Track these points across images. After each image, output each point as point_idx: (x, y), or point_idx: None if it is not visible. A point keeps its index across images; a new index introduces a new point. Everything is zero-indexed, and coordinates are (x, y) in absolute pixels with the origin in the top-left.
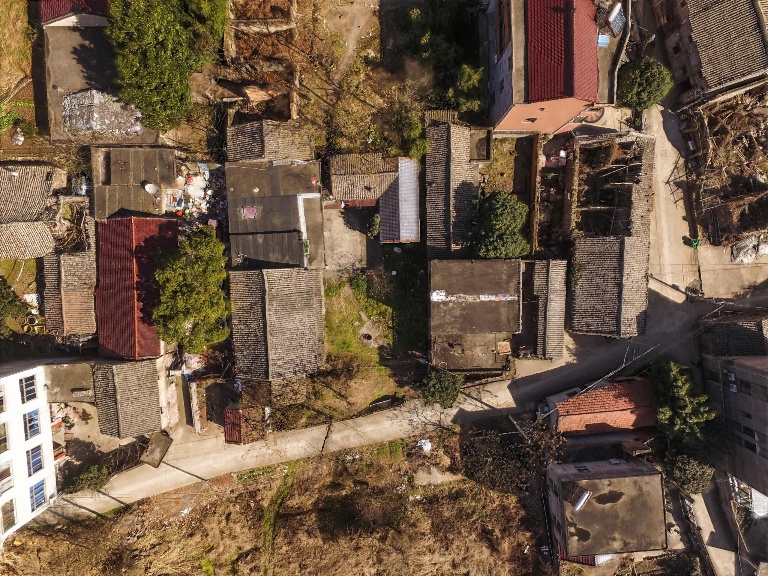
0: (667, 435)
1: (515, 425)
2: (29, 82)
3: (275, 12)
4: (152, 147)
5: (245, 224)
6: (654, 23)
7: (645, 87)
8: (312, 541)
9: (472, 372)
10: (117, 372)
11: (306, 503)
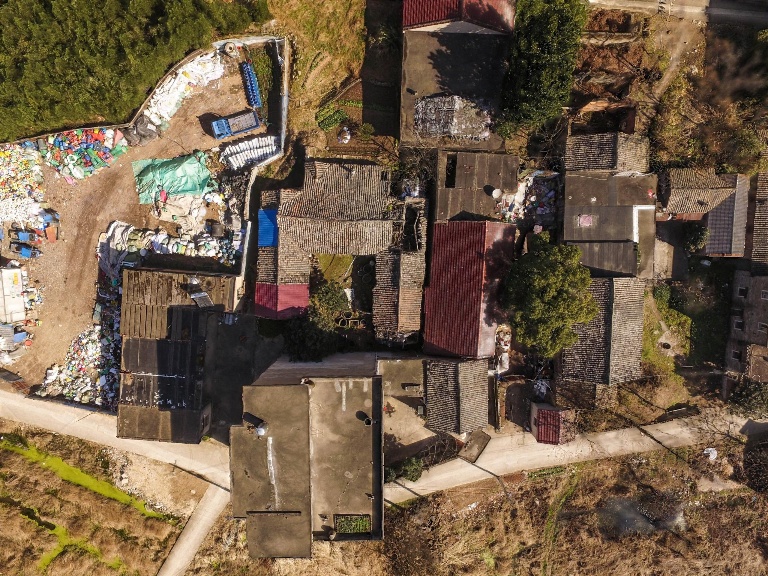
0: None
1: None
2: (358, 82)
3: (611, 25)
4: (497, 153)
5: (580, 232)
6: None
7: None
8: (592, 540)
9: None
10: (460, 370)
11: (590, 503)
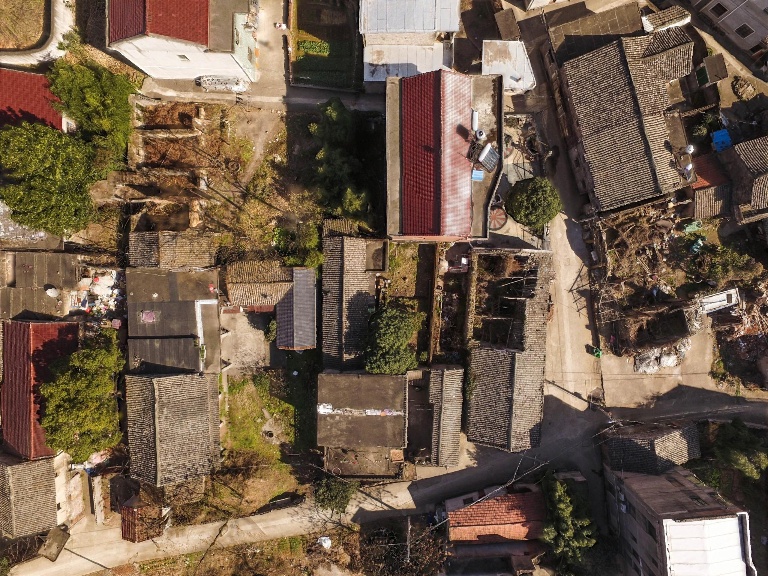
0: (555, 553)
1: (409, 531)
2: None
3: (182, 119)
4: (56, 252)
5: (144, 328)
6: (558, 133)
7: (531, 211)
8: None
9: (364, 479)
10: (12, 472)
11: None
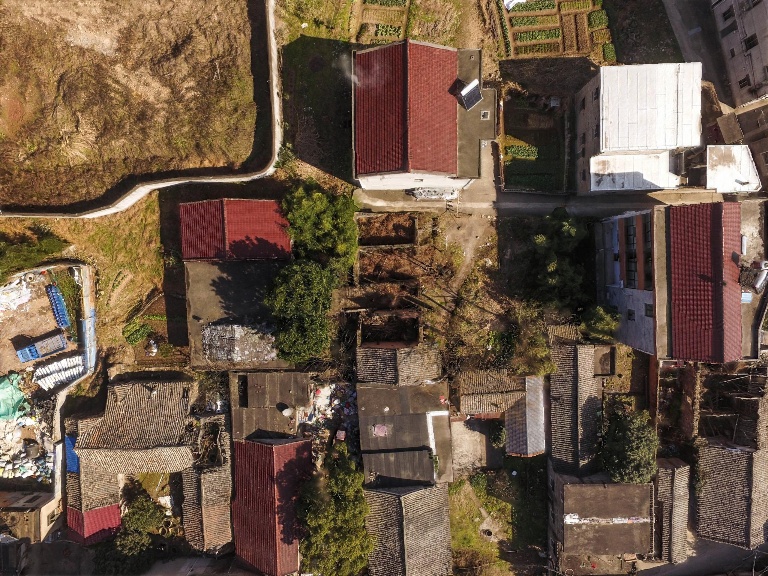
0: None
1: None
2: (161, 296)
3: (397, 230)
4: (287, 371)
5: (376, 441)
6: None
7: None
8: None
9: None
10: None
11: None
